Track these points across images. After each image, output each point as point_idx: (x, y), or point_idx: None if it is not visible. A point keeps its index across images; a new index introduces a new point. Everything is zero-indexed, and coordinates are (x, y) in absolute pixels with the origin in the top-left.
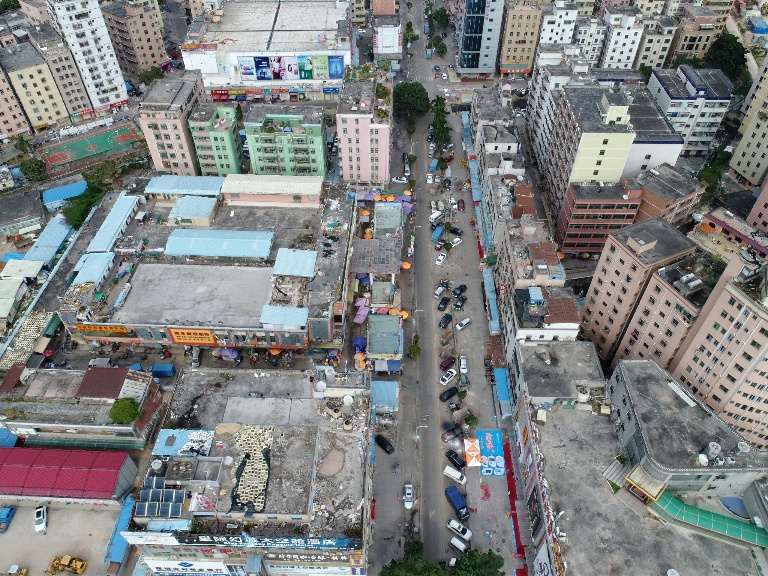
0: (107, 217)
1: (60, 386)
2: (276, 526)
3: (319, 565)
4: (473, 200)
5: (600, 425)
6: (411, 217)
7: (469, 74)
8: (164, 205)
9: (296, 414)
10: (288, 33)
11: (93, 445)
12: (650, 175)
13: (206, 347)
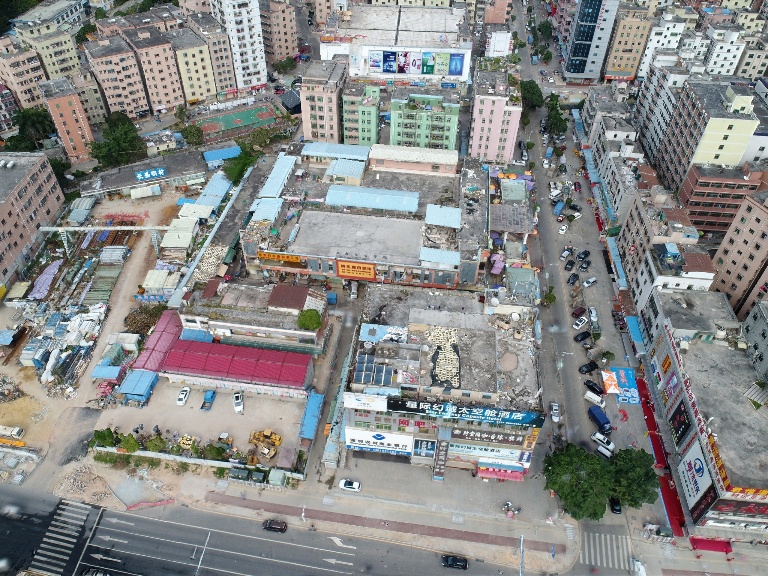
0: (272, 171)
1: (249, 299)
2: (467, 403)
3: (494, 446)
4: (591, 182)
5: (737, 358)
6: (532, 194)
7: (574, 79)
8: (317, 166)
9: (471, 324)
10: (412, 33)
11: (278, 348)
12: (767, 162)
13: (365, 282)
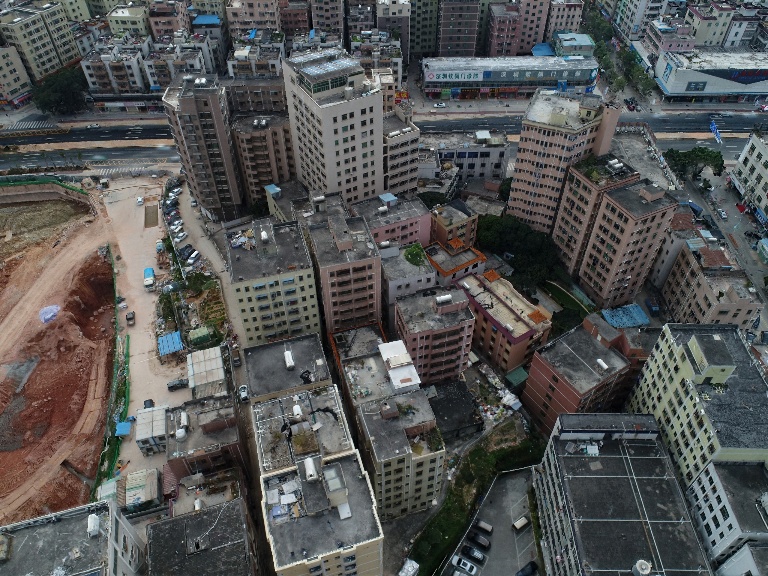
0: None
1: None
2: None
3: None
4: None
5: None
6: None
7: None
8: None
9: None
10: None
11: None
12: None
13: None
